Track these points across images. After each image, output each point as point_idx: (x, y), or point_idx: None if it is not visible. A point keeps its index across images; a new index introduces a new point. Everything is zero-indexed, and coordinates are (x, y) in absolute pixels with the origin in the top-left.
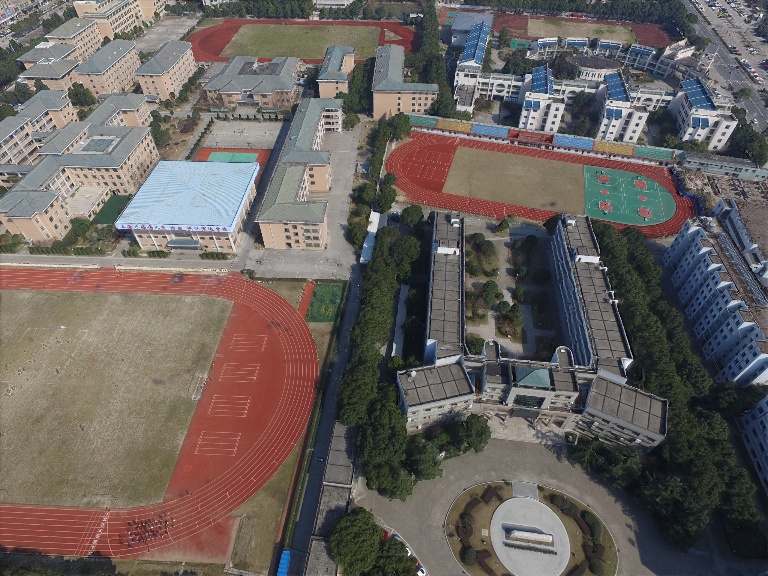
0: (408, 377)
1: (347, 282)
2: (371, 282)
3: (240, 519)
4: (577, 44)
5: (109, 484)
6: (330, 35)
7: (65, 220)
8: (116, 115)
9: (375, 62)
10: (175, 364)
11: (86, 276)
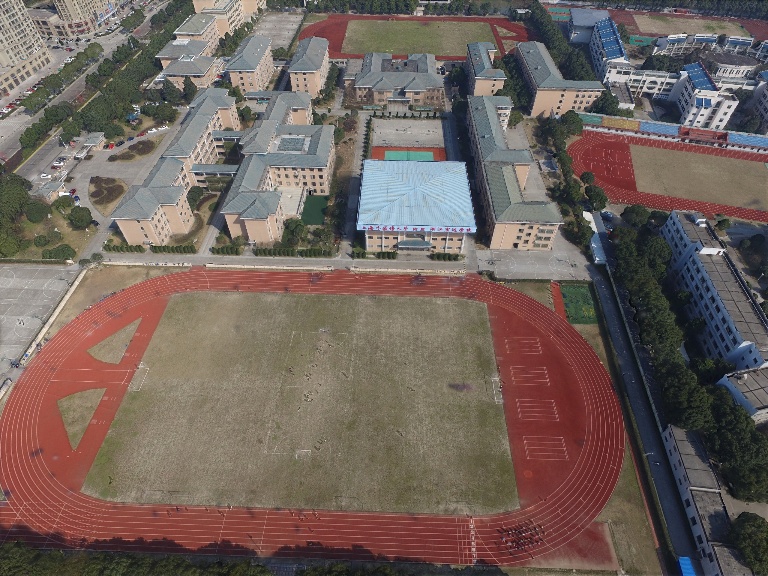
0: (737, 380)
1: (594, 283)
2: (635, 283)
3: (608, 525)
4: (706, 40)
5: (457, 490)
6: (442, 31)
7: (281, 221)
8: (289, 113)
9: (522, 59)
10: (460, 367)
11: (324, 278)
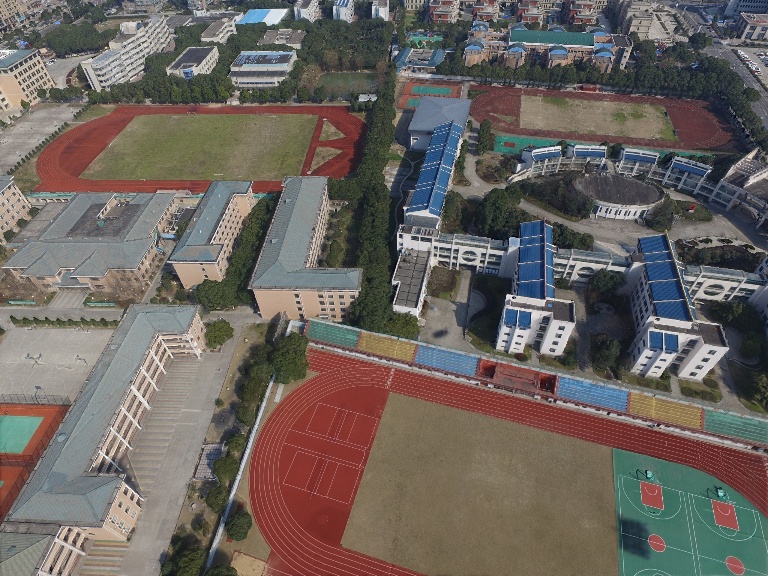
0: None
1: None
2: None
3: None
4: (591, 154)
5: None
6: (246, 132)
7: None
8: None
9: (275, 212)
10: None
11: None
